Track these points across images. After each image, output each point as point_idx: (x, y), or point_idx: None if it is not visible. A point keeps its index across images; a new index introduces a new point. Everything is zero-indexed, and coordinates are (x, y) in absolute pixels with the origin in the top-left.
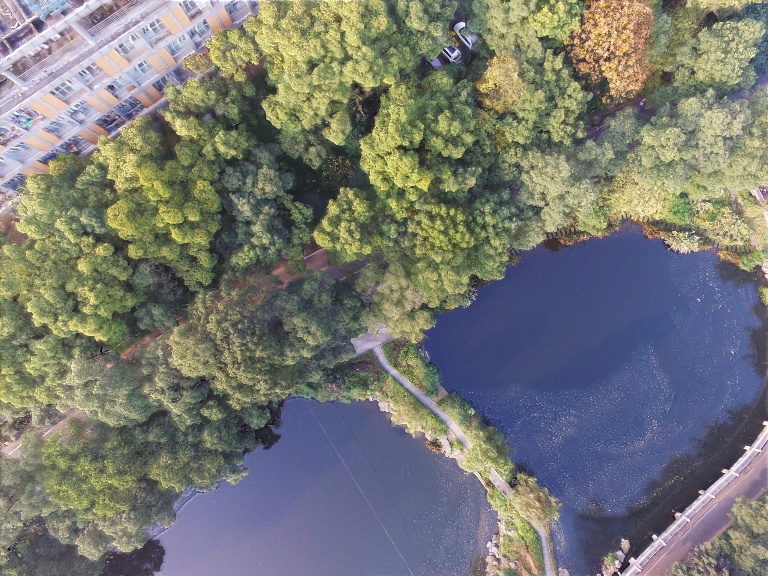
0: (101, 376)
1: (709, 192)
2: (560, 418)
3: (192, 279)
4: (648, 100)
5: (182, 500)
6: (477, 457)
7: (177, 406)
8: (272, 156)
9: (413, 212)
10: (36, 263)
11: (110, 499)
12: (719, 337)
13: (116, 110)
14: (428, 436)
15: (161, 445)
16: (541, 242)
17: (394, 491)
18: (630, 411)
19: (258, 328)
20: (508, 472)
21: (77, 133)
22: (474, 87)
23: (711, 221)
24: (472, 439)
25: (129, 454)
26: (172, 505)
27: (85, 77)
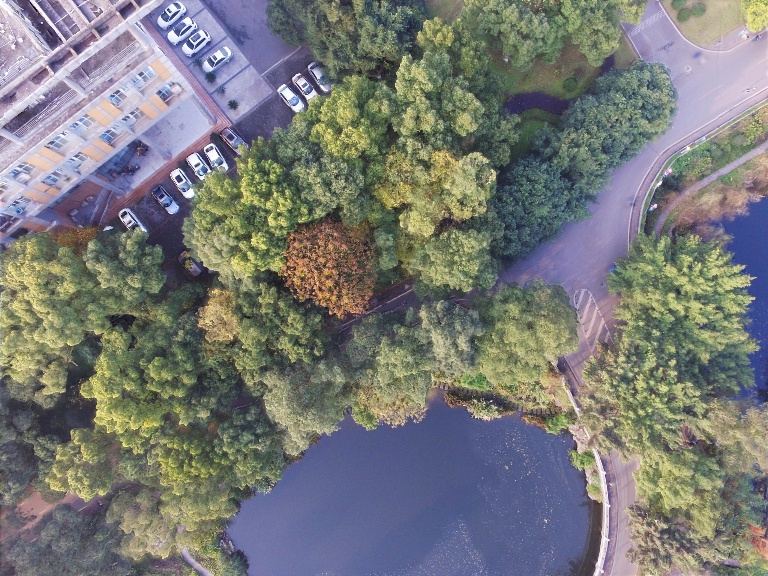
0: None
1: None
2: None
3: None
4: None
5: None
6: None
7: None
8: None
9: None
10: None
11: None
12: (530, 505)
13: None
14: None
15: None
16: None
17: None
18: None
19: None
20: None
21: None
22: (196, 320)
23: (508, 389)
24: None
25: None
26: None
27: None
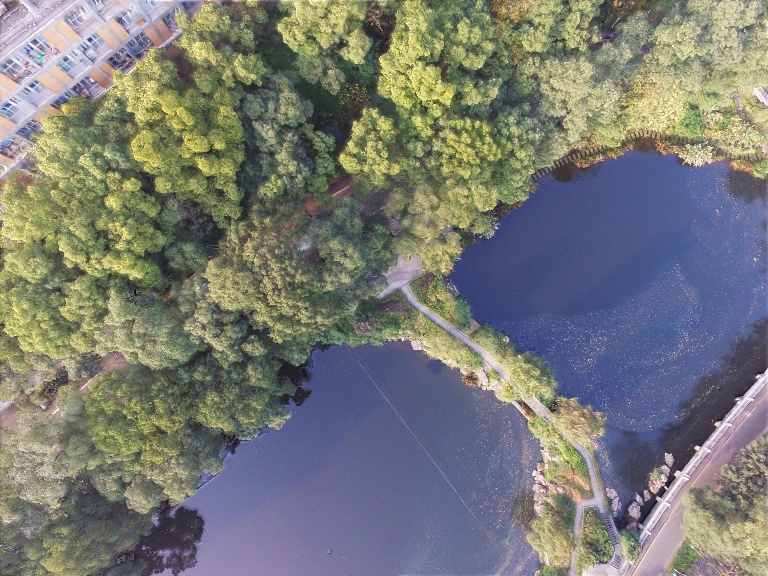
0: (138, 315)
1: (719, 100)
2: (593, 339)
3: (220, 214)
4: (653, 11)
5: (226, 449)
6: (519, 378)
7: (219, 341)
8: (292, 82)
9: (437, 131)
10: (62, 203)
11: (157, 444)
12: (740, 245)
13: (128, 48)
14: (463, 371)
15: (204, 386)
16: (558, 167)
17: (432, 435)
18: (661, 326)
19: (295, 252)
20: (547, 397)
21: (90, 74)
22: None
23: (723, 130)
24: (510, 365)
25: (173, 395)
26: (217, 453)
27: (97, 7)
